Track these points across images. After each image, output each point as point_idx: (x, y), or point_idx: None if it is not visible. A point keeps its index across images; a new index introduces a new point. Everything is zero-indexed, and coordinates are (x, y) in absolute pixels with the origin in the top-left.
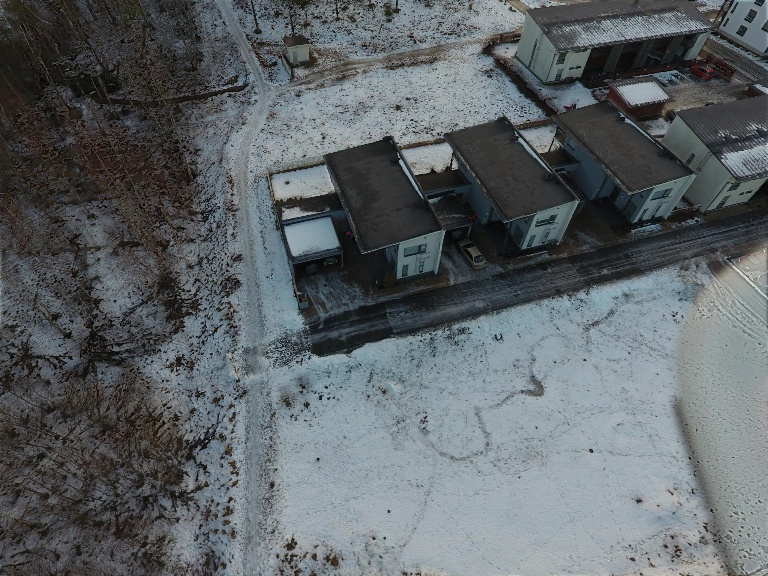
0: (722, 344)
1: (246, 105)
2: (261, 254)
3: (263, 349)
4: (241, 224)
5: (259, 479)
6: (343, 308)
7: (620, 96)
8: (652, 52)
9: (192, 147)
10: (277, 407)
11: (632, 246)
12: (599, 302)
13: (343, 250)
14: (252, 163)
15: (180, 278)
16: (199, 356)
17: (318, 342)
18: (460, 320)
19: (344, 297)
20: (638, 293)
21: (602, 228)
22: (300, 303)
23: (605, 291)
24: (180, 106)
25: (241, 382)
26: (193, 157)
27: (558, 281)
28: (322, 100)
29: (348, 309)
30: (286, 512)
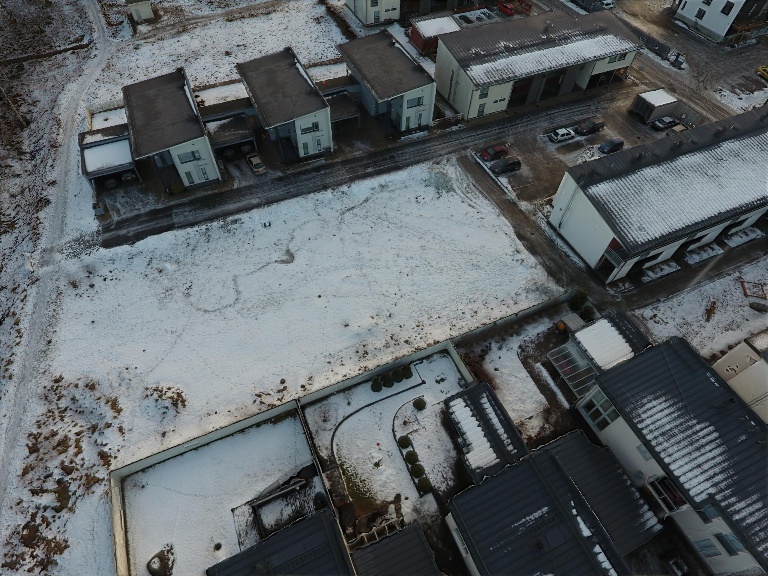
0: (448, 215)
1: (86, 60)
2: (74, 179)
3: (59, 248)
4: (61, 157)
5: (39, 338)
6: (135, 212)
7: (417, 30)
8: None
9: (30, 99)
10: (64, 288)
11: (398, 149)
12: (358, 193)
13: (135, 165)
14: (81, 108)
15: (3, 206)
16: (8, 261)
17: (107, 238)
18: (235, 214)
19: (138, 204)
20: (392, 184)
21: (377, 137)
22: (94, 209)
23: (364, 184)
24: (23, 65)
25: (35, 273)
26: (30, 108)
27: (327, 179)
28: (157, 51)
29: (139, 213)
30: (58, 359)
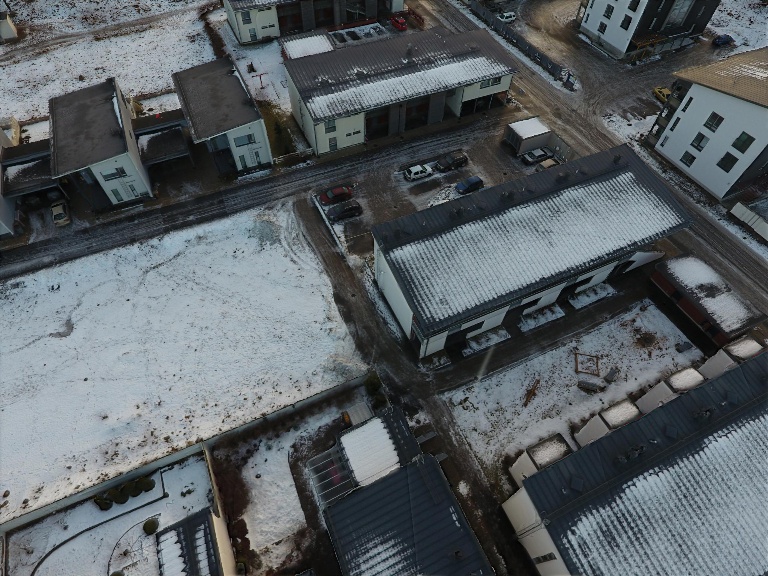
0: (265, 273)
1: None
2: None
3: None
4: None
5: None
6: None
7: (284, 51)
8: (350, 6)
9: None
10: None
11: (231, 192)
12: (169, 246)
13: None
14: None
15: None
16: None
17: None
18: (19, 275)
19: None
20: (212, 235)
21: (210, 178)
22: None
23: (178, 236)
24: None
25: None
26: None
27: (138, 231)
28: (6, 76)
29: None
30: None
